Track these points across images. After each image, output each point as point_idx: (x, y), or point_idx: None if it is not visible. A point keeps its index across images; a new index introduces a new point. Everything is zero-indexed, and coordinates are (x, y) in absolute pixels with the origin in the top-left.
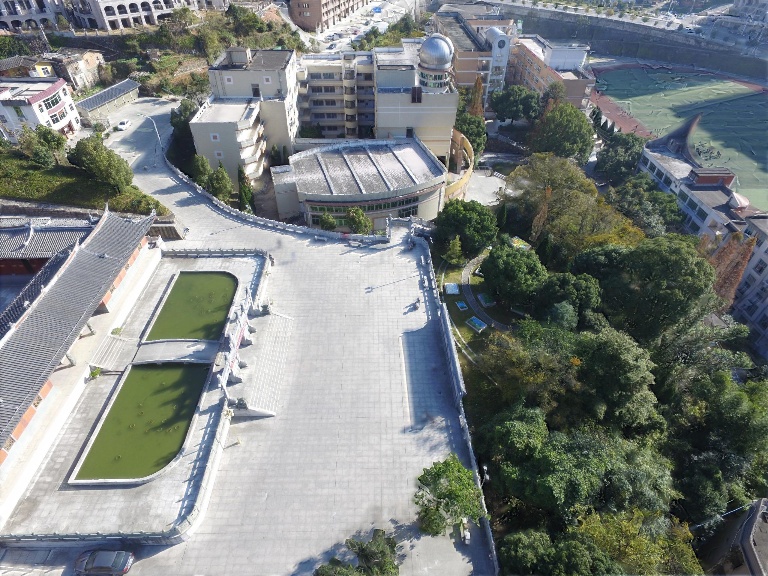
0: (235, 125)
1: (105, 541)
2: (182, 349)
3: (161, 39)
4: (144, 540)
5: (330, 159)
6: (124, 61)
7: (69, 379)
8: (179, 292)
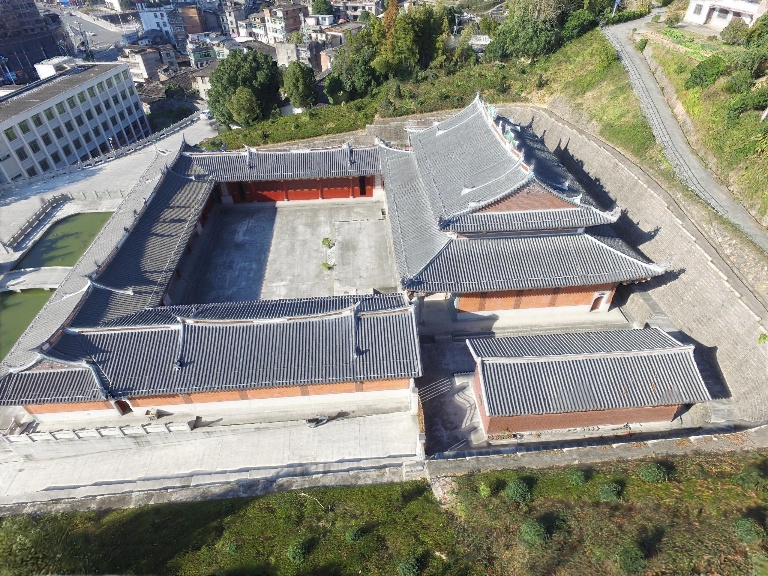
0: None
1: None
2: (31, 278)
3: None
4: None
5: None
6: None
7: None
8: None
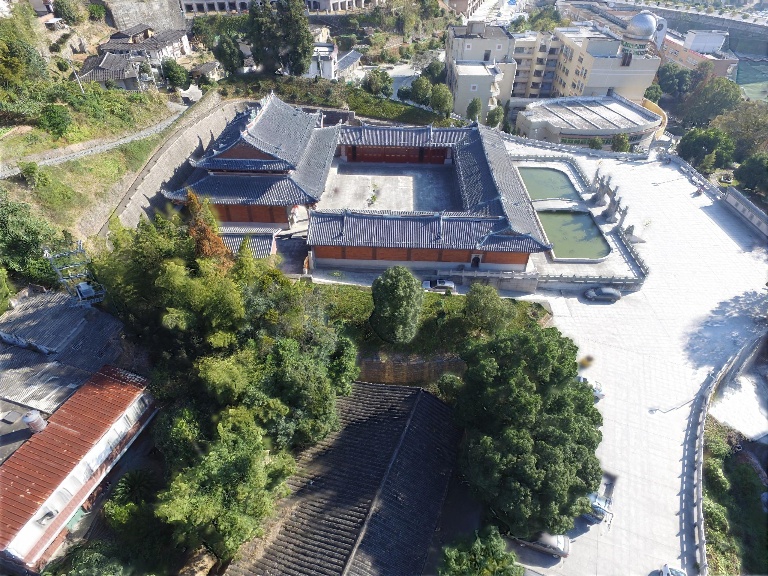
0: (493, 78)
1: (598, 285)
2: (565, 204)
3: (374, 19)
4: (622, 285)
5: (556, 109)
6: (347, 36)
7: None
8: (527, 178)
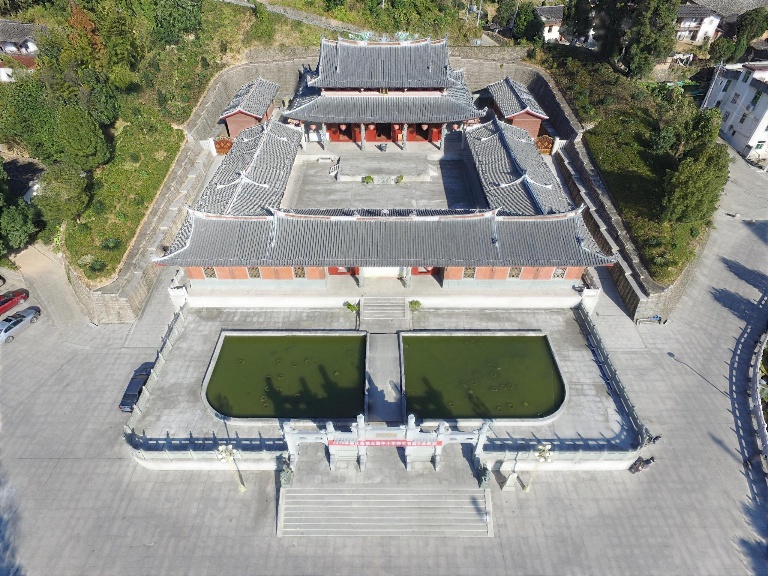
0: None
1: None
2: (387, 376)
3: None
4: None
5: None
6: None
7: (341, 289)
8: (503, 346)
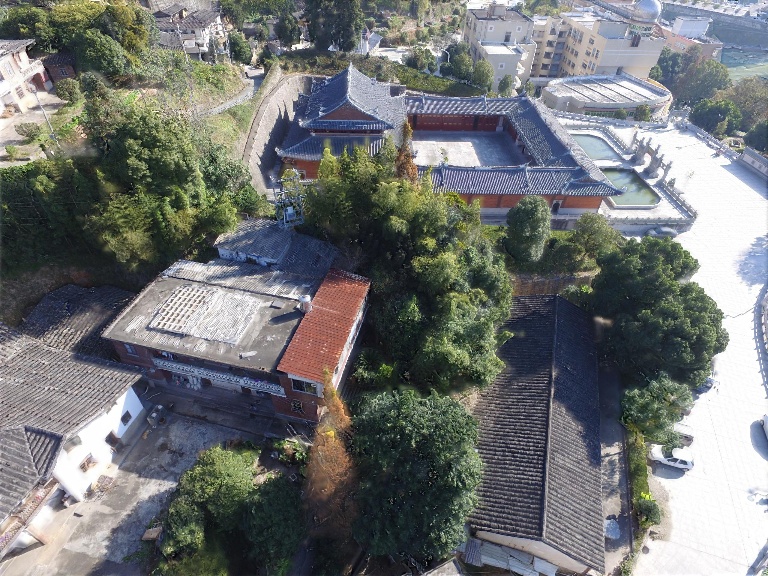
0: (520, 57)
1: (656, 226)
2: (611, 163)
3: (391, 3)
4: (676, 226)
5: (575, 86)
6: (366, 19)
7: None
8: None
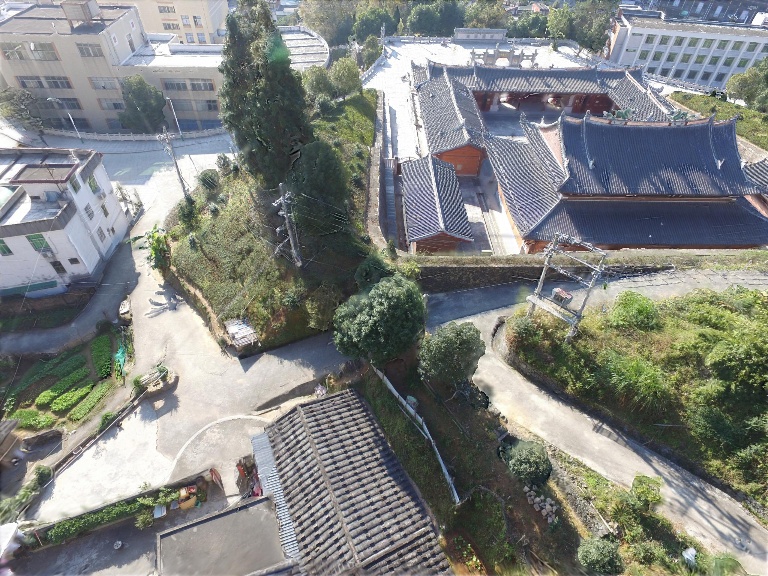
0: None
1: None
2: None
3: None
4: None
5: None
6: None
7: None
8: None
